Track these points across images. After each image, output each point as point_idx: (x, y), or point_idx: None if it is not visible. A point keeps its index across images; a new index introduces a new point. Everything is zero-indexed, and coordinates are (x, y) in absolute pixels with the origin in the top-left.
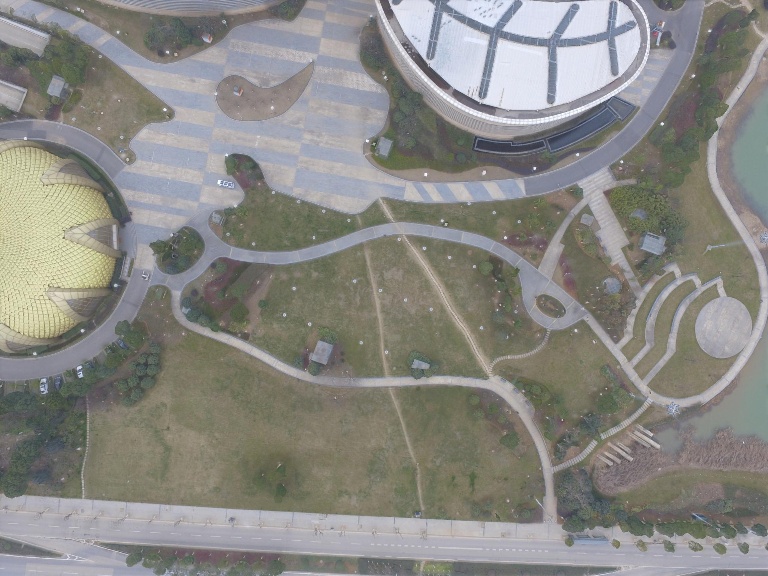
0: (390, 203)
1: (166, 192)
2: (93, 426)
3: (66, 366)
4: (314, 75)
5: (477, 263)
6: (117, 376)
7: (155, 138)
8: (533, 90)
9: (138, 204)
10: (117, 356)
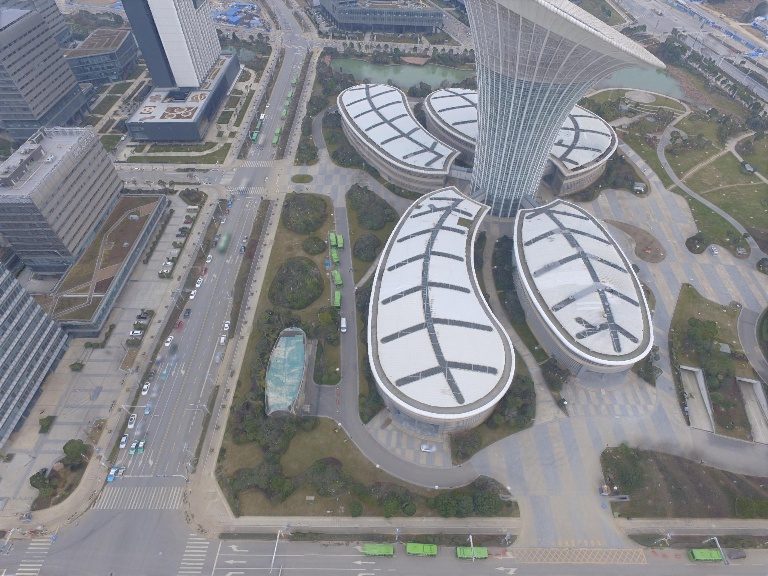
0: (667, 186)
1: (743, 283)
2: None
3: None
4: None
5: (674, 156)
6: None
7: (710, 292)
8: (596, 121)
9: (765, 297)
10: None
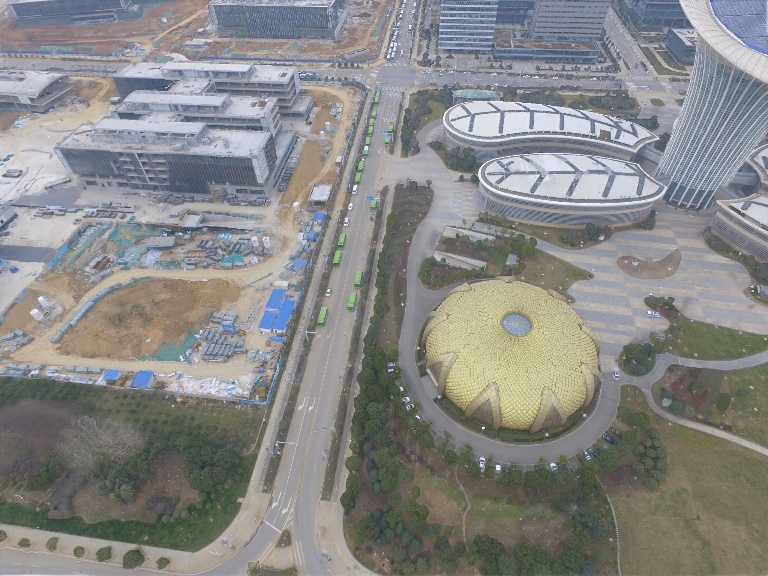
0: None
1: (607, 320)
2: (619, 513)
3: (569, 452)
4: (682, 255)
5: None
6: (622, 462)
7: (585, 288)
8: None
9: None
10: (634, 432)
